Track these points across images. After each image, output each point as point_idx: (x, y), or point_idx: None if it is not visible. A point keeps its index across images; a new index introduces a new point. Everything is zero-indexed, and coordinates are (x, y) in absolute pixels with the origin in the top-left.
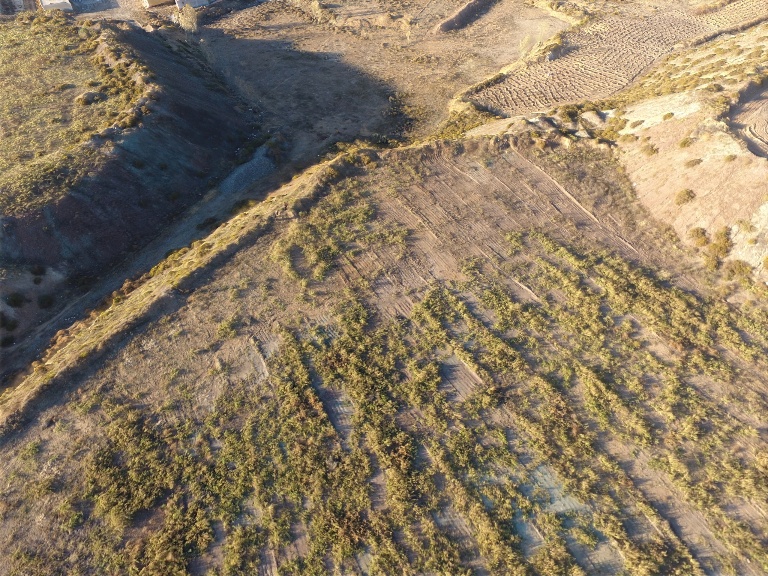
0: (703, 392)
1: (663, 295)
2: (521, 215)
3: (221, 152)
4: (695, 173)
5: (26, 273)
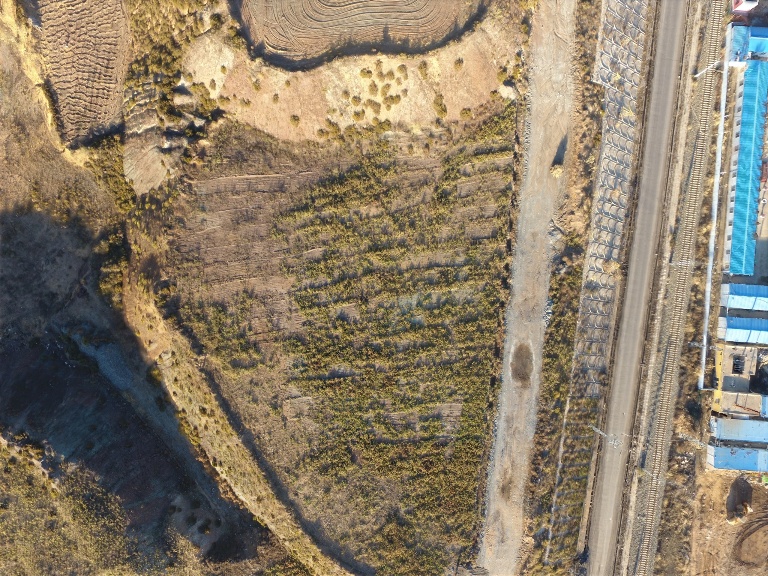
0: (399, 209)
1: (348, 186)
2: (259, 217)
3: (74, 380)
4: (283, 105)
5: (173, 517)
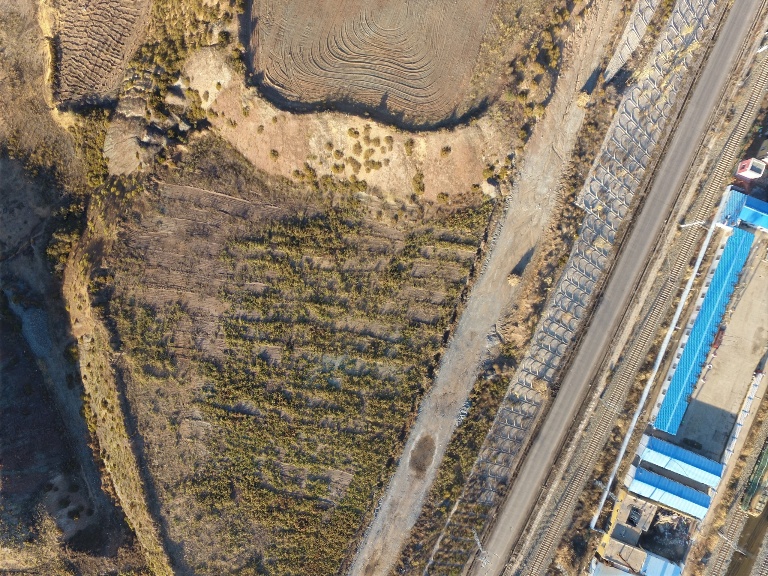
0: (350, 270)
1: (308, 232)
2: (214, 236)
3: None
4: (266, 137)
5: (47, 494)
